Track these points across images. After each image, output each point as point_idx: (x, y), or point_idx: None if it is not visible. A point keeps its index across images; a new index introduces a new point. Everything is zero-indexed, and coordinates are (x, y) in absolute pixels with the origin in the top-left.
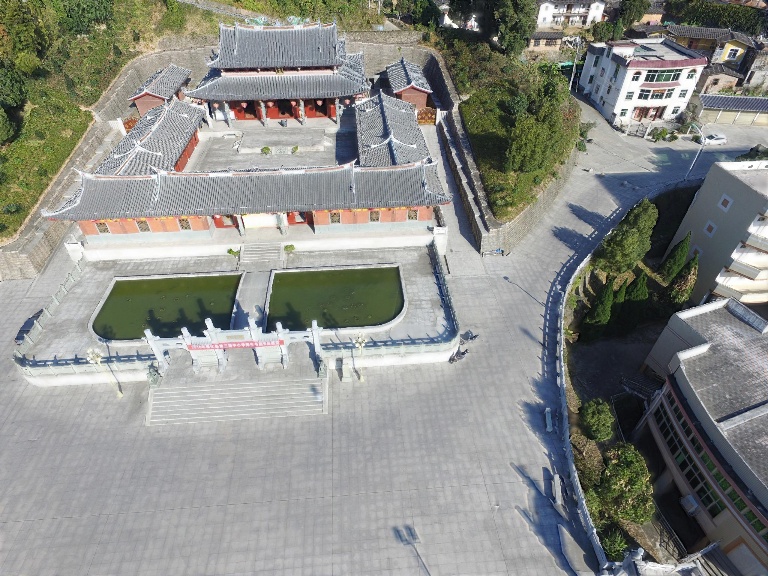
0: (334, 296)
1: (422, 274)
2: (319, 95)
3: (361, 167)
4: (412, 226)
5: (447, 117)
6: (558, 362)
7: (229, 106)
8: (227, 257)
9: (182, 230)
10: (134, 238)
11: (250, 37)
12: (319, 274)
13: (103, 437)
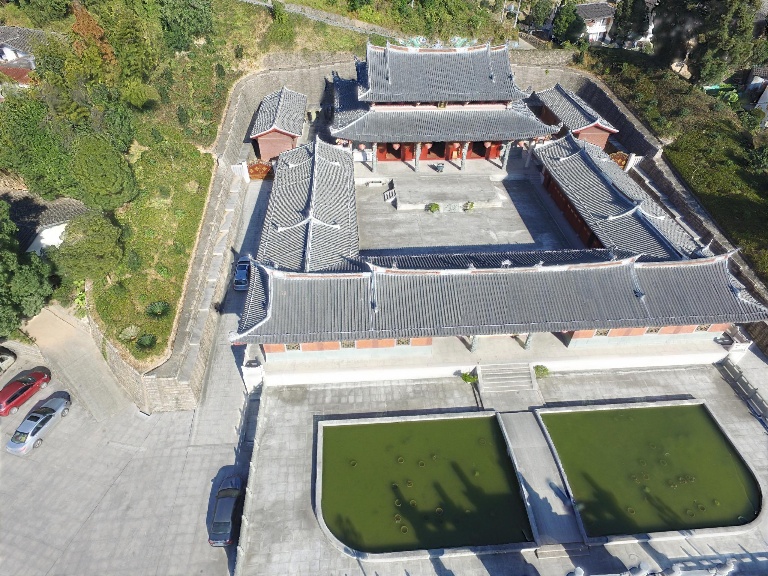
0: (643, 460)
1: (738, 416)
2: (494, 137)
3: (643, 262)
4: (695, 337)
5: (642, 164)
6: None
7: (370, 145)
8: (454, 381)
9: (397, 345)
10: (329, 355)
11: (404, 62)
12: (599, 416)
13: None
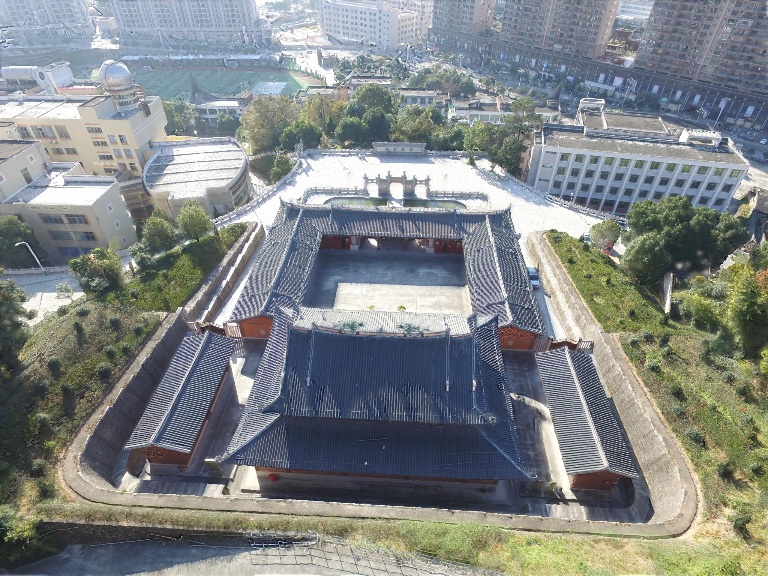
0: None
1: None
2: None
3: None
4: None
5: None
6: (270, 194)
7: None
8: None
9: None
10: None
11: None
12: None
13: (442, 189)
